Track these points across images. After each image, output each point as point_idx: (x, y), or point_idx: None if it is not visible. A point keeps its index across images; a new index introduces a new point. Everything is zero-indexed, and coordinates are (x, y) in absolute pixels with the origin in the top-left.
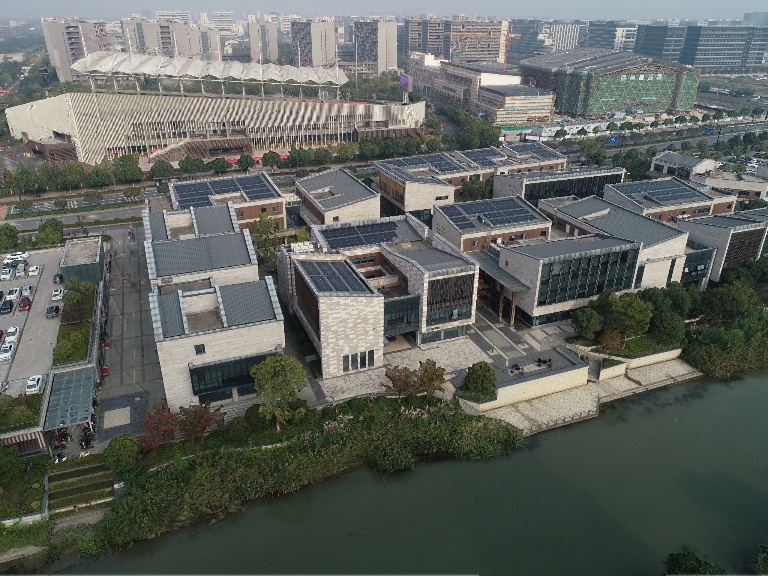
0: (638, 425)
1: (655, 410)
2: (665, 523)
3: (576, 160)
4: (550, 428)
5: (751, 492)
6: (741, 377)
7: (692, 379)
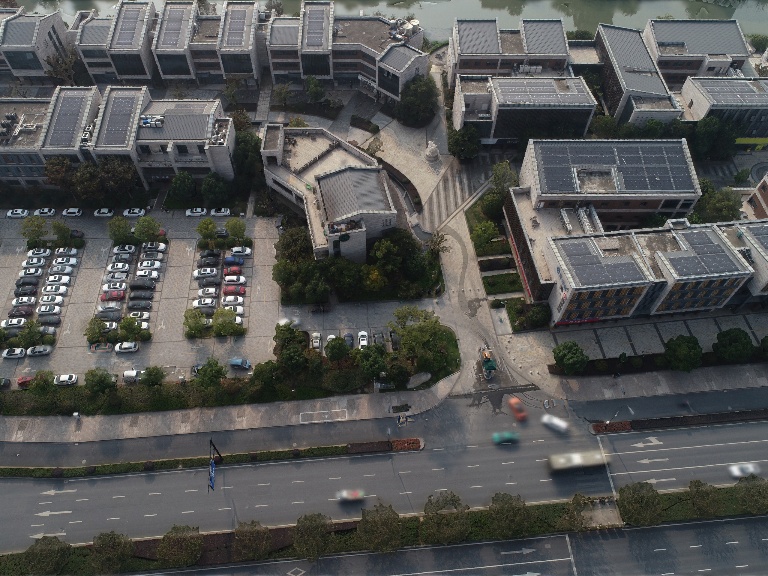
0: None
1: None
2: (684, 8)
3: (350, 463)
4: None
5: (643, 4)
6: None
7: None
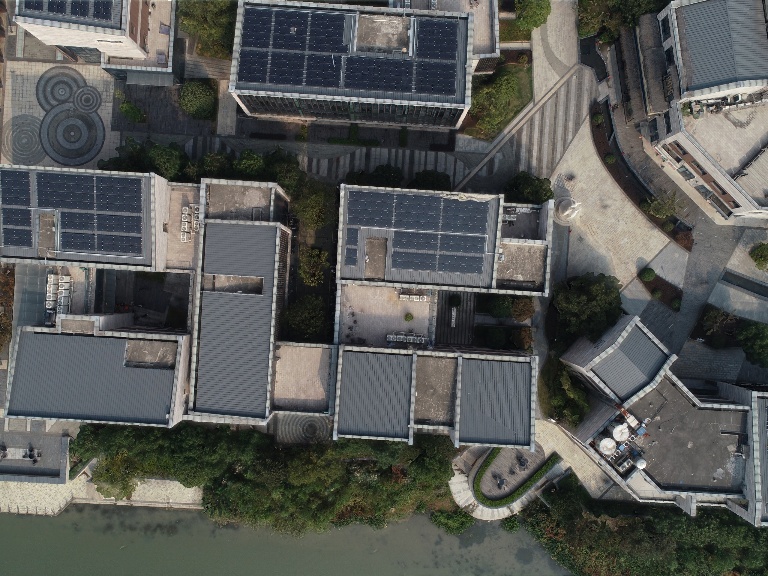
0: (83, 539)
1: (114, 530)
2: None
3: None
4: (3, 512)
5: None
6: (239, 528)
7: (189, 510)
